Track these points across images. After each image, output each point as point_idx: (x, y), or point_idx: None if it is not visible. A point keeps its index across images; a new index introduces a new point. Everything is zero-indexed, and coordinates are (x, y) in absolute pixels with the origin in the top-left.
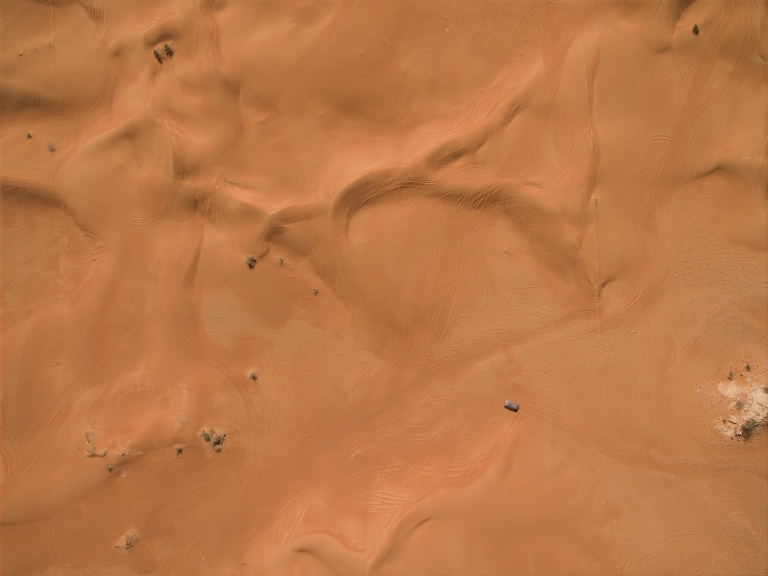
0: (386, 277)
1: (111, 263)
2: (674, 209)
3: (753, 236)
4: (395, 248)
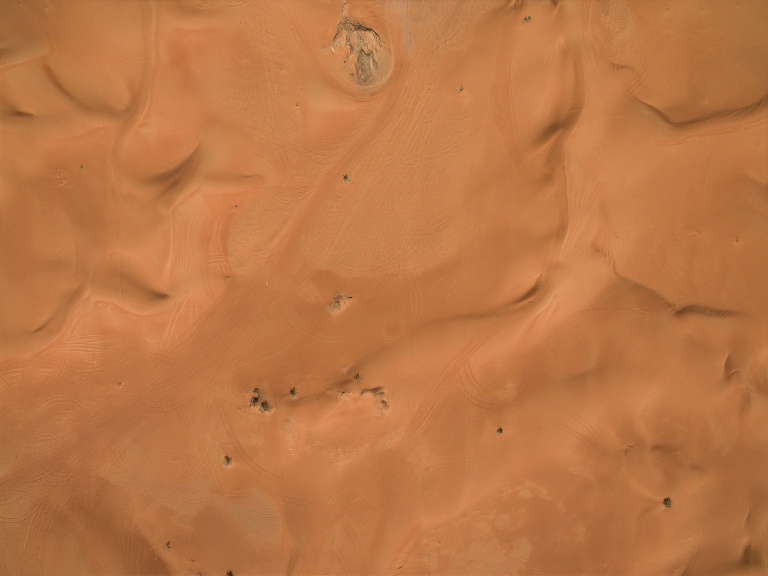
0: (91, 567)
1: (379, 569)
2: None
3: None
4: None
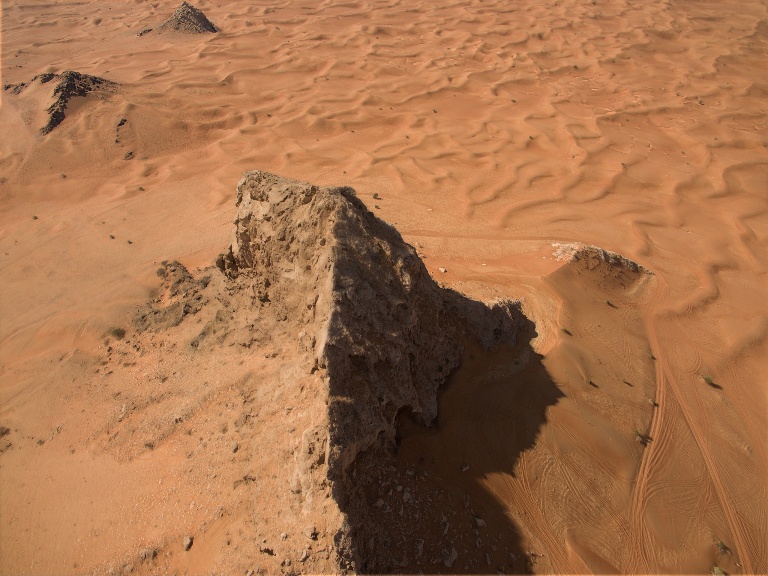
0: None
1: None
2: None
3: None
4: None
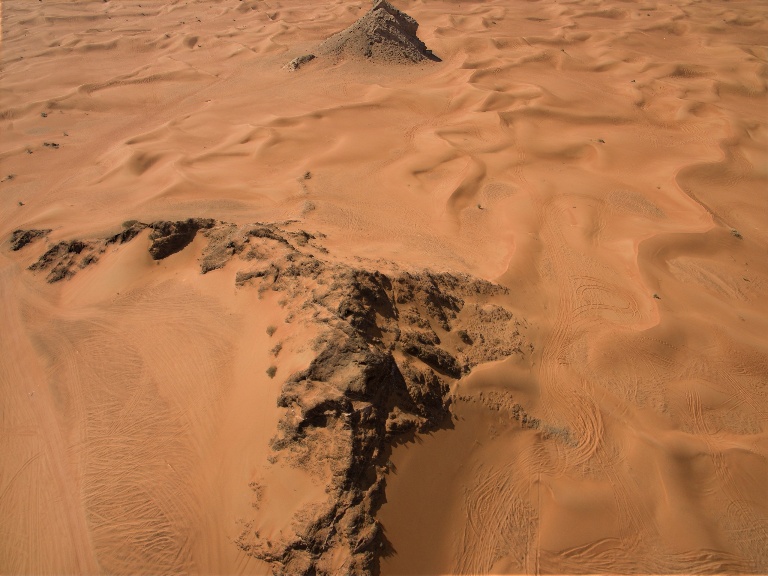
0: None
1: None
2: None
3: None
4: None
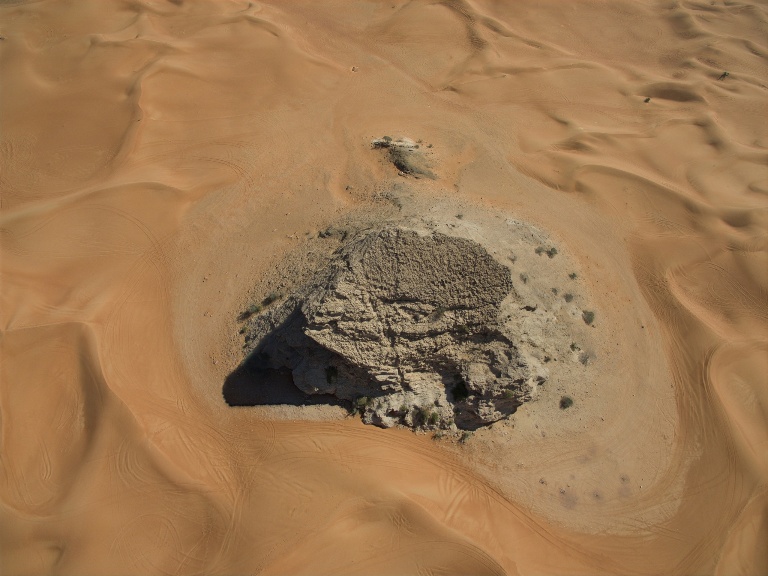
0: (414, 18)
1: None
2: (523, 112)
3: (530, 144)
4: (431, 18)
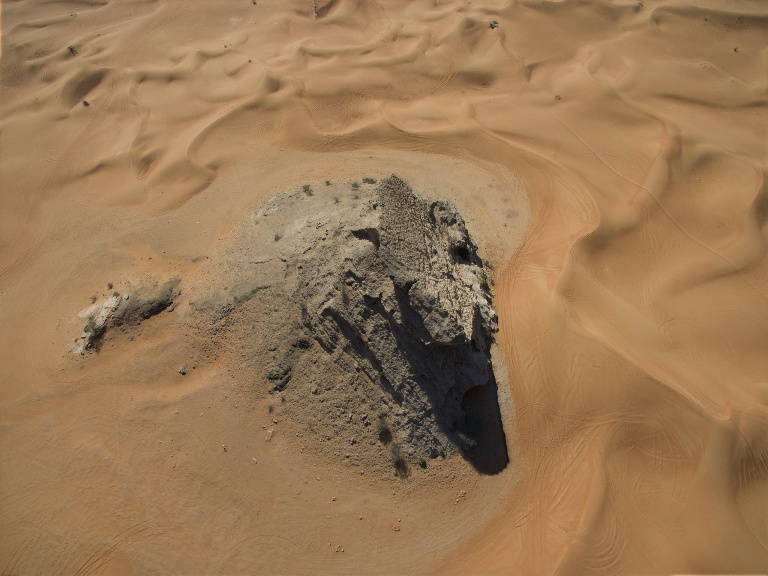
0: None
1: None
2: (60, 199)
3: (130, 197)
4: None
